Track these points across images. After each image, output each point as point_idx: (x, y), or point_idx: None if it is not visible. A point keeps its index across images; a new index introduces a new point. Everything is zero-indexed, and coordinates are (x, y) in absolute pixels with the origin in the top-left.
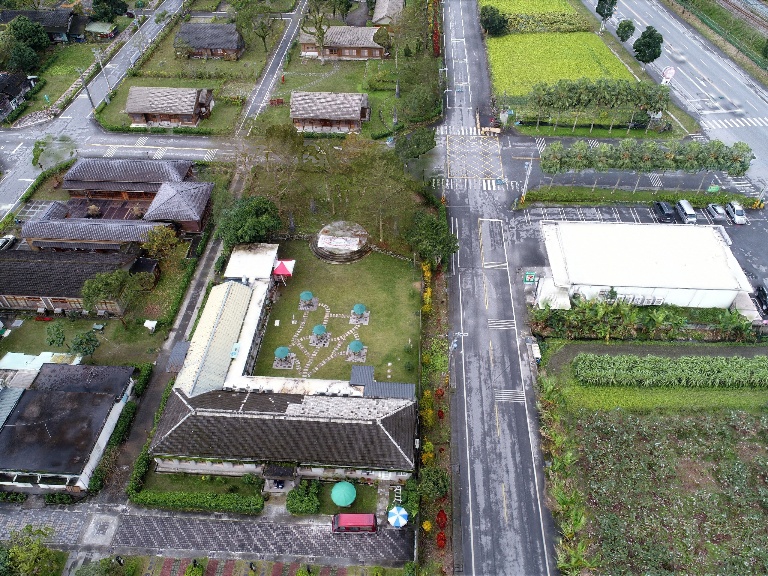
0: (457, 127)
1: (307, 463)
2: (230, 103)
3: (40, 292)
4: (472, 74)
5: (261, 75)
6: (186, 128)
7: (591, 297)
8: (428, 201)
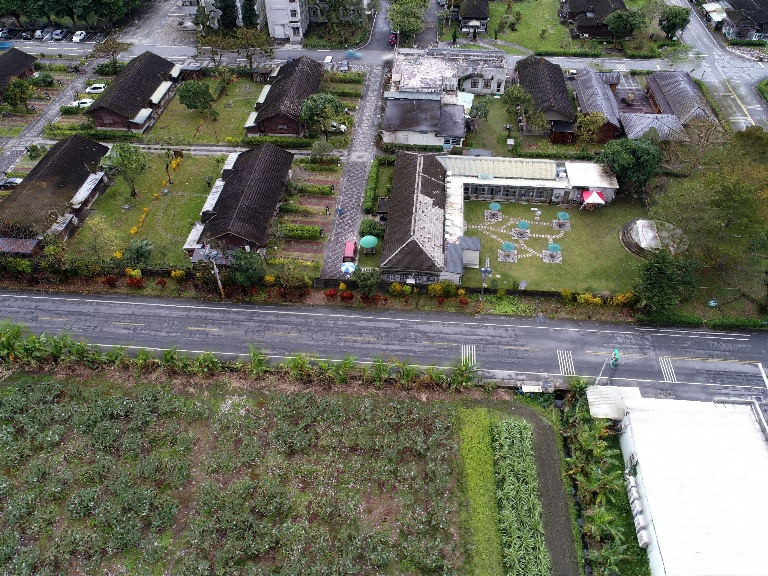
0: None
1: None
2: None
3: None
4: None
5: None
6: None
7: (626, 451)
8: None
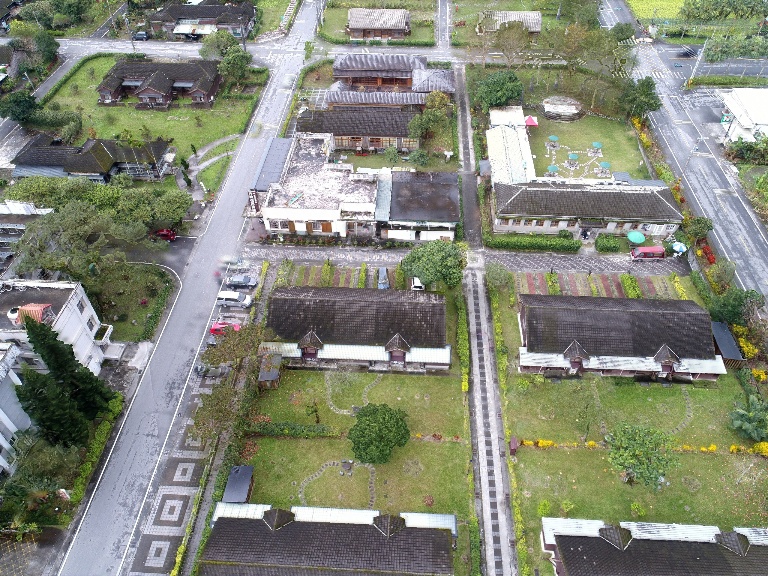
0: None
1: (608, 219)
2: (423, 24)
3: (364, 132)
4: (612, 4)
5: (436, 6)
6: (399, 40)
7: (767, 136)
8: None
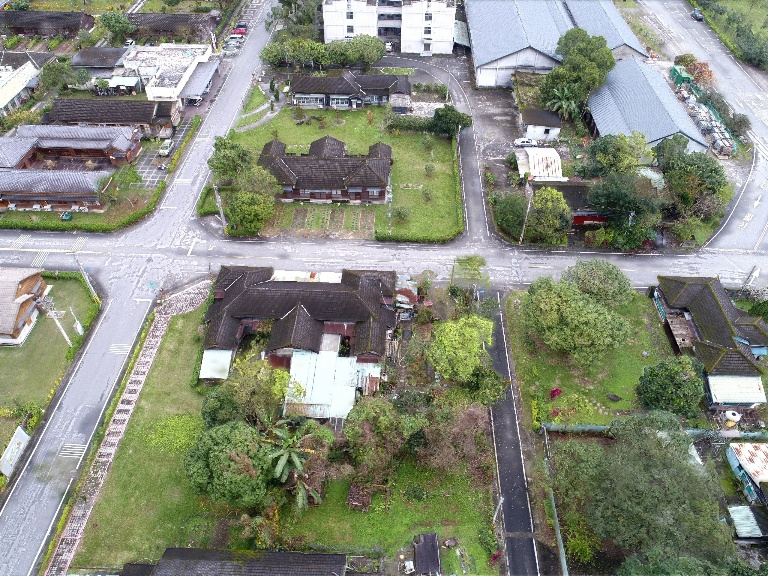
0: None
1: None
2: None
3: None
4: None
5: None
6: None
7: None
8: None
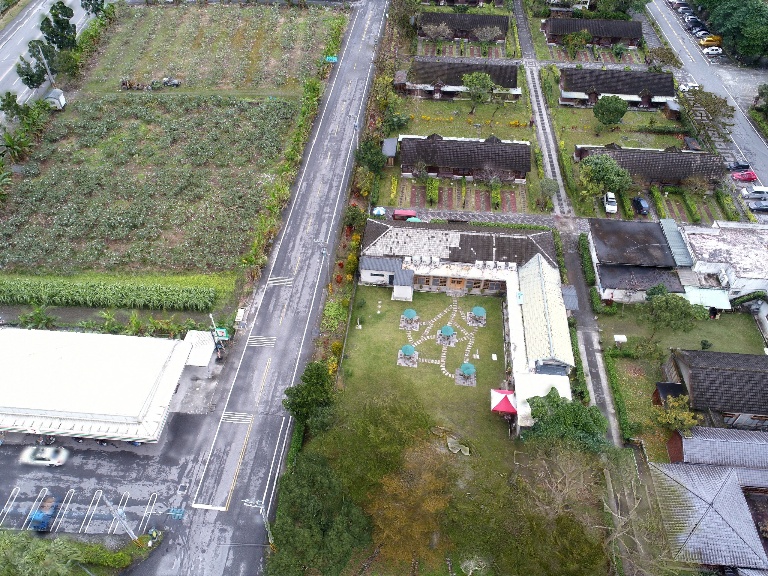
0: None
1: None
2: None
3: (760, 356)
4: None
5: None
6: None
7: None
8: None
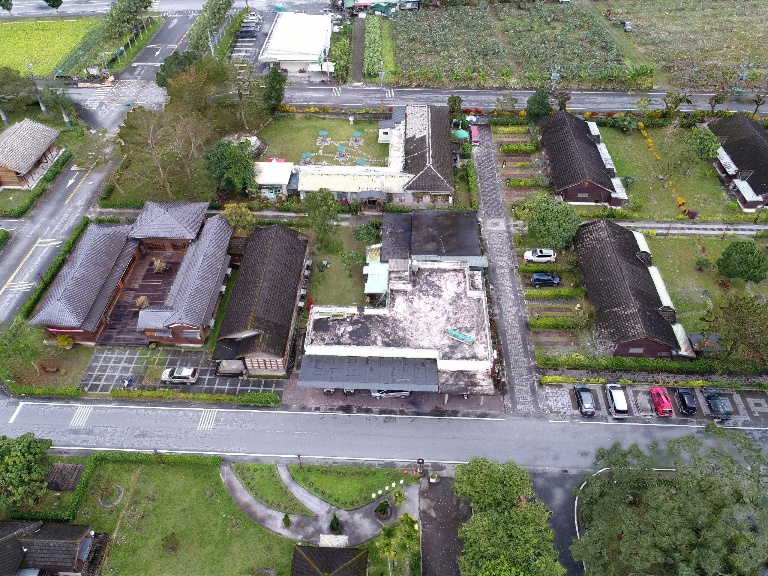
0: (92, 96)
1: None
2: None
3: (296, 283)
4: None
5: None
6: None
7: None
8: (200, 111)
